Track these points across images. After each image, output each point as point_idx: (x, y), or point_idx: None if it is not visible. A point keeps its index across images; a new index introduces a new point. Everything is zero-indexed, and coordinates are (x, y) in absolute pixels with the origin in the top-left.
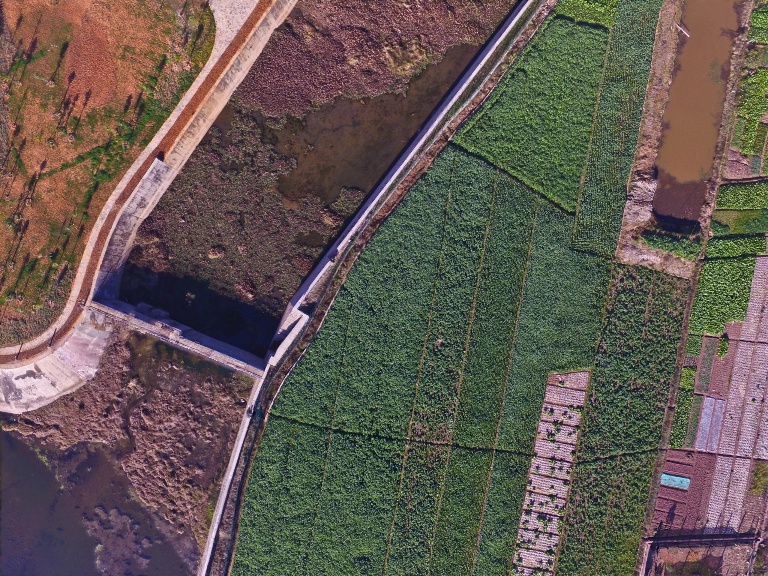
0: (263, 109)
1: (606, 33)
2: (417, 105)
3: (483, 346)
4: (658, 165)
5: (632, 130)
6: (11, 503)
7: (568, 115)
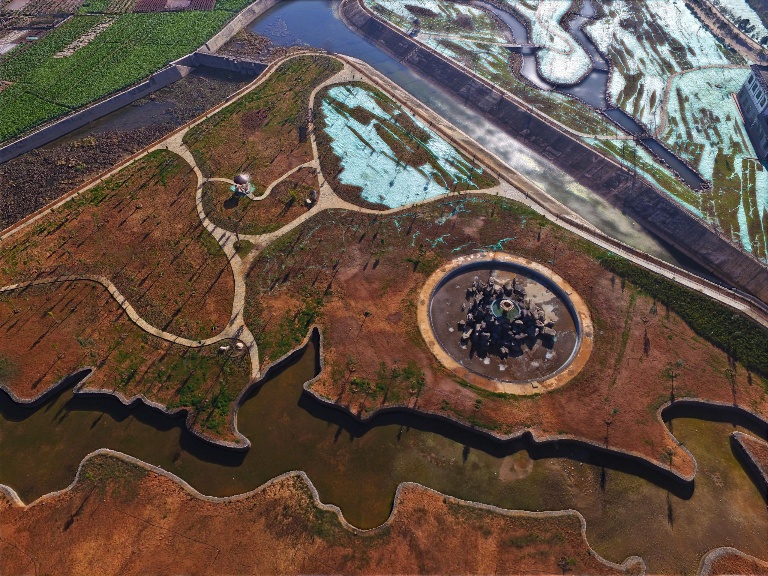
0: None
1: None
2: None
3: None
4: None
5: None
6: None
7: None
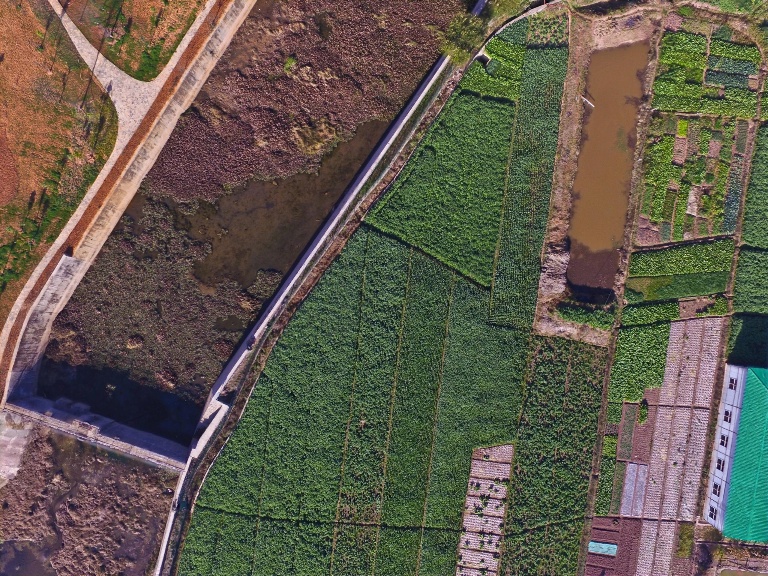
0: (174, 195)
1: (512, 107)
2: (330, 183)
3: (406, 425)
4: (570, 235)
5: (543, 202)
6: None
7: (478, 190)
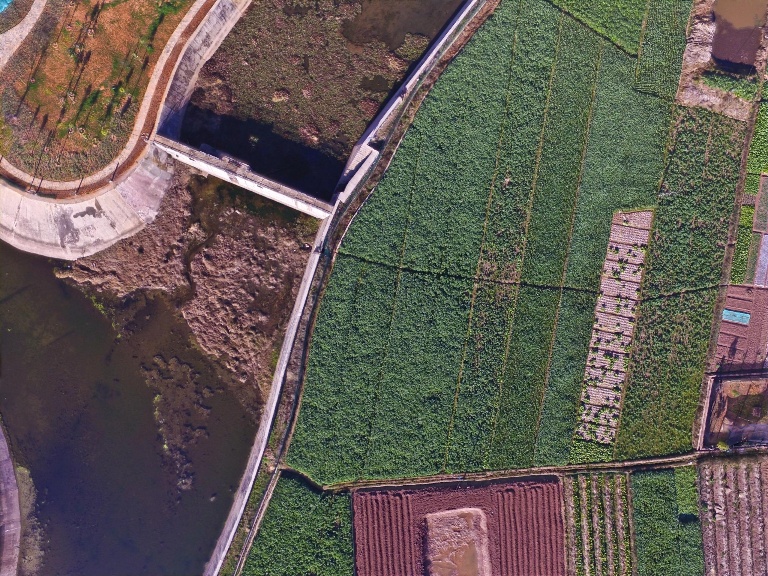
0: None
1: None
2: None
3: (550, 185)
4: (715, 11)
5: None
6: (64, 353)
7: None
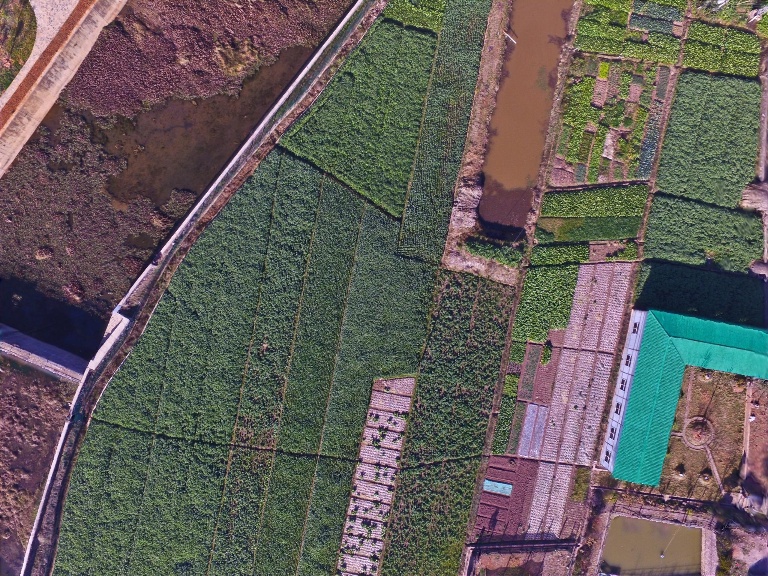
0: (92, 108)
1: (434, 38)
2: (250, 107)
3: (308, 351)
4: (485, 172)
5: (458, 136)
6: None
7: (395, 120)
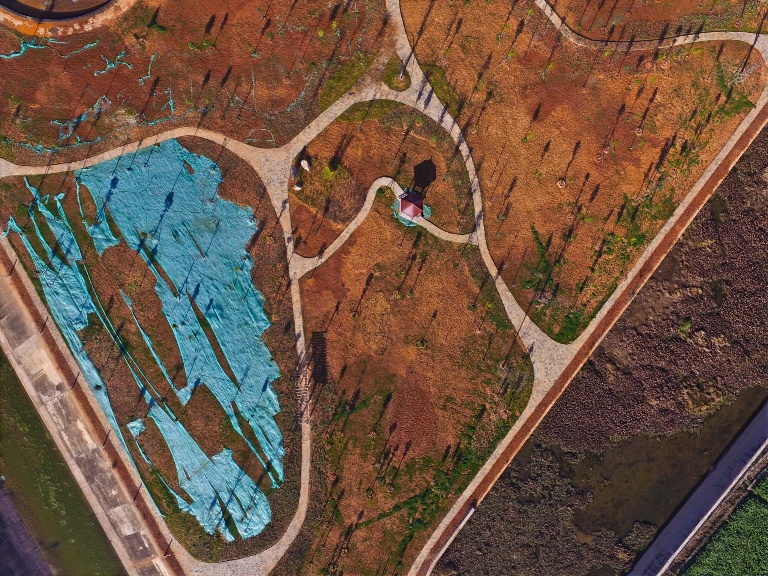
0: (563, 444)
1: None
2: (709, 443)
3: None
4: None
5: None
6: None
7: None
